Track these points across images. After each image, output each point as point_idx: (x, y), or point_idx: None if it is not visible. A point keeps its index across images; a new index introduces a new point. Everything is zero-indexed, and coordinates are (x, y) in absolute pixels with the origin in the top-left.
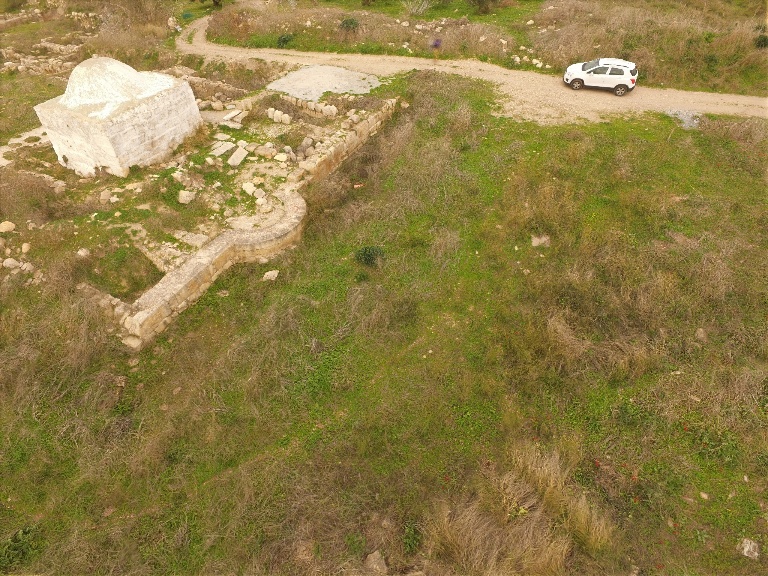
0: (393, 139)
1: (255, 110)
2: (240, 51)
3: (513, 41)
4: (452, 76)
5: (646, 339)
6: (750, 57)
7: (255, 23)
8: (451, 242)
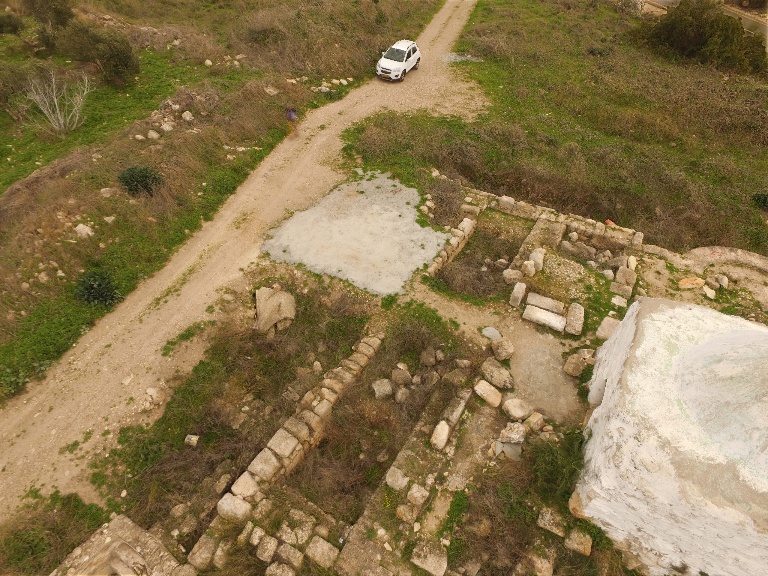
0: None
1: (534, 283)
2: (51, 398)
3: None
4: (349, 133)
5: (759, 117)
6: (387, 11)
7: None
8: (718, 163)
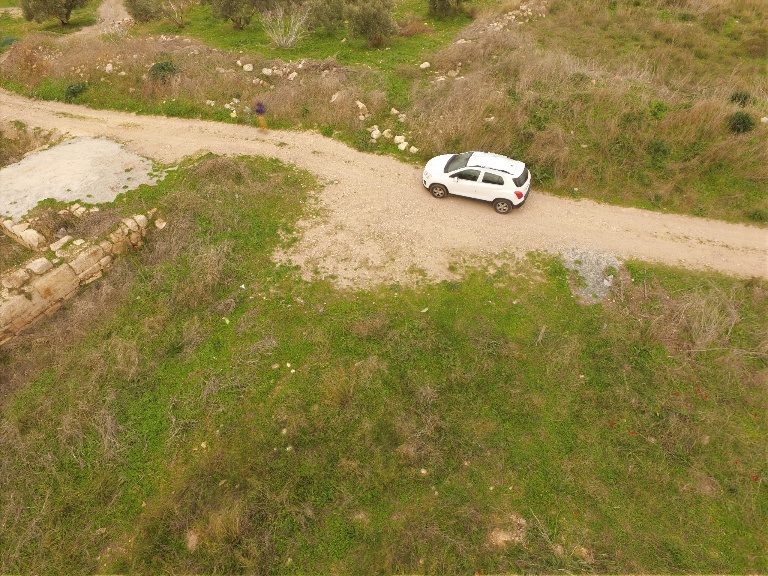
0: (70, 318)
1: None
2: (18, 105)
3: (389, 97)
4: (269, 163)
5: None
6: (718, 149)
7: (50, 63)
8: None
